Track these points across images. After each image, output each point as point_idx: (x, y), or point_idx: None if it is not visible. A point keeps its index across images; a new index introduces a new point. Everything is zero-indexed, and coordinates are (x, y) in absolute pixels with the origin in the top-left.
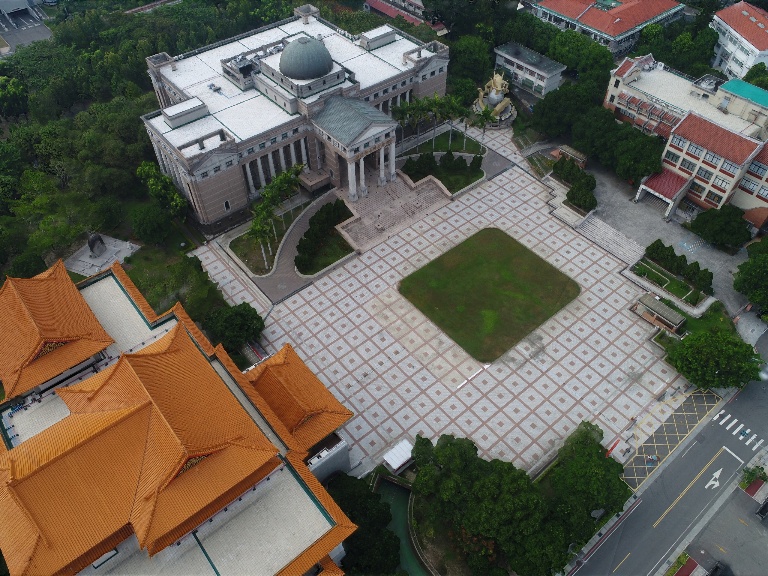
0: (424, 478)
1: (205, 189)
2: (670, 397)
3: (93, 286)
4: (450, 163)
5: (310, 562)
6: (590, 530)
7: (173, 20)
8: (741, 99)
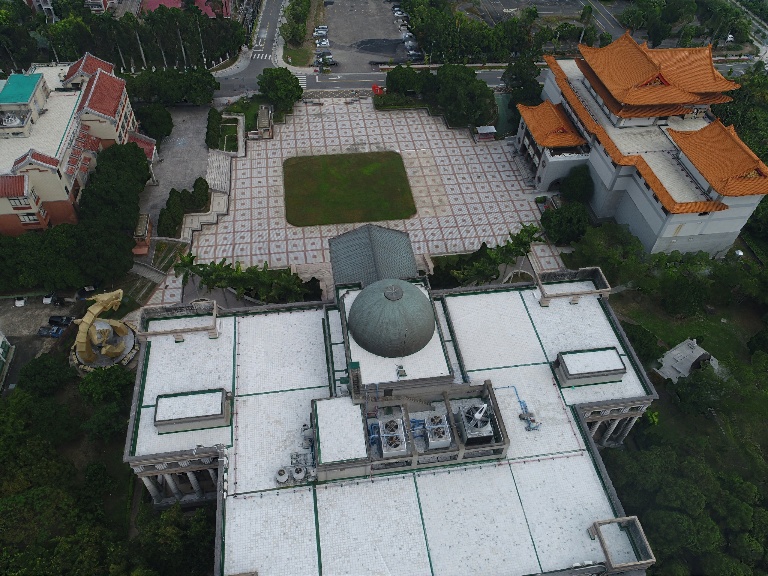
0: None
1: None
2: (314, 102)
3: None
4: None
5: None
6: None
7: None
8: (36, 91)
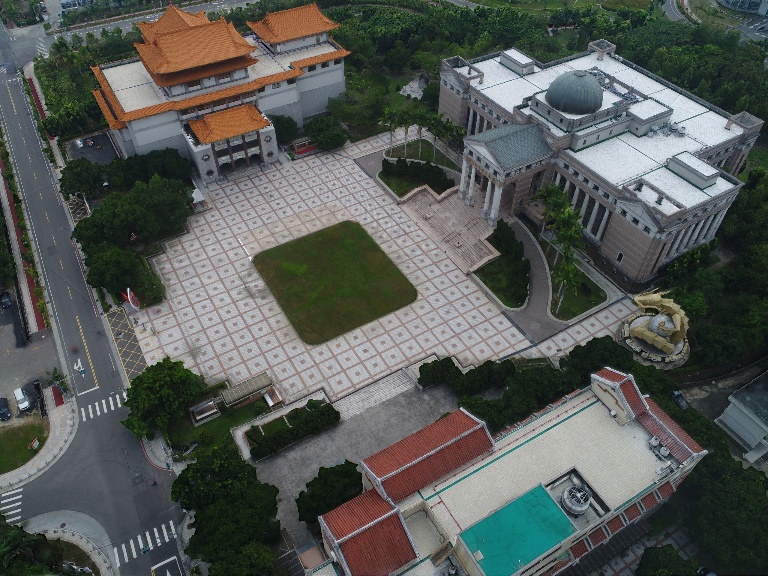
0: None
1: None
2: None
3: (333, 48)
4: None
5: None
6: None
7: (766, 81)
8: None
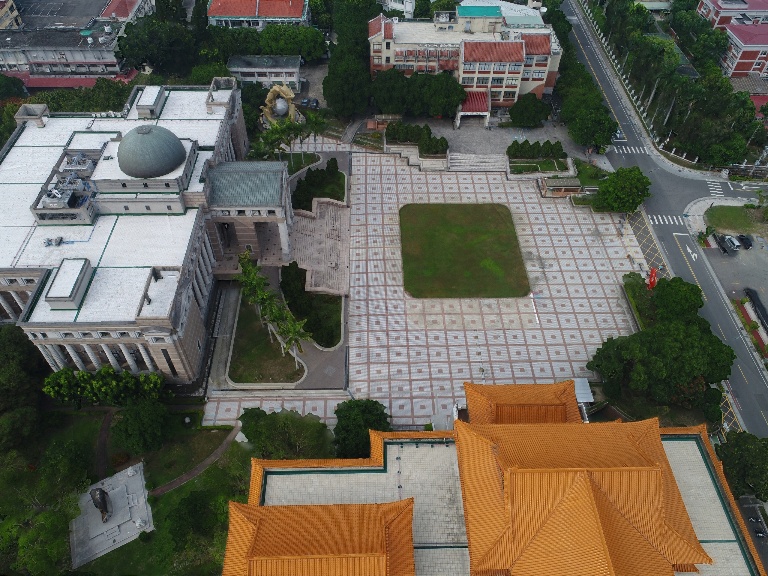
0: (643, 377)
1: (186, 341)
2: (623, 229)
3: (269, 500)
4: (318, 178)
5: (720, 470)
6: (709, 325)
7: None
8: (479, 18)
